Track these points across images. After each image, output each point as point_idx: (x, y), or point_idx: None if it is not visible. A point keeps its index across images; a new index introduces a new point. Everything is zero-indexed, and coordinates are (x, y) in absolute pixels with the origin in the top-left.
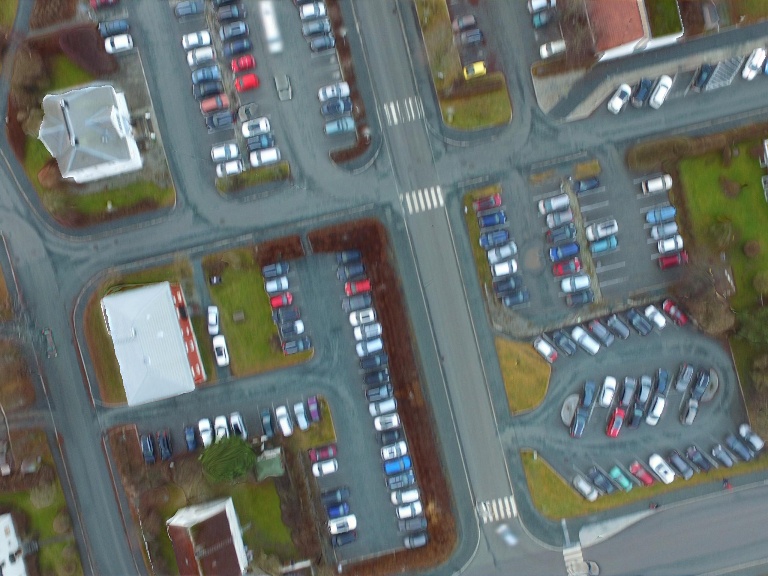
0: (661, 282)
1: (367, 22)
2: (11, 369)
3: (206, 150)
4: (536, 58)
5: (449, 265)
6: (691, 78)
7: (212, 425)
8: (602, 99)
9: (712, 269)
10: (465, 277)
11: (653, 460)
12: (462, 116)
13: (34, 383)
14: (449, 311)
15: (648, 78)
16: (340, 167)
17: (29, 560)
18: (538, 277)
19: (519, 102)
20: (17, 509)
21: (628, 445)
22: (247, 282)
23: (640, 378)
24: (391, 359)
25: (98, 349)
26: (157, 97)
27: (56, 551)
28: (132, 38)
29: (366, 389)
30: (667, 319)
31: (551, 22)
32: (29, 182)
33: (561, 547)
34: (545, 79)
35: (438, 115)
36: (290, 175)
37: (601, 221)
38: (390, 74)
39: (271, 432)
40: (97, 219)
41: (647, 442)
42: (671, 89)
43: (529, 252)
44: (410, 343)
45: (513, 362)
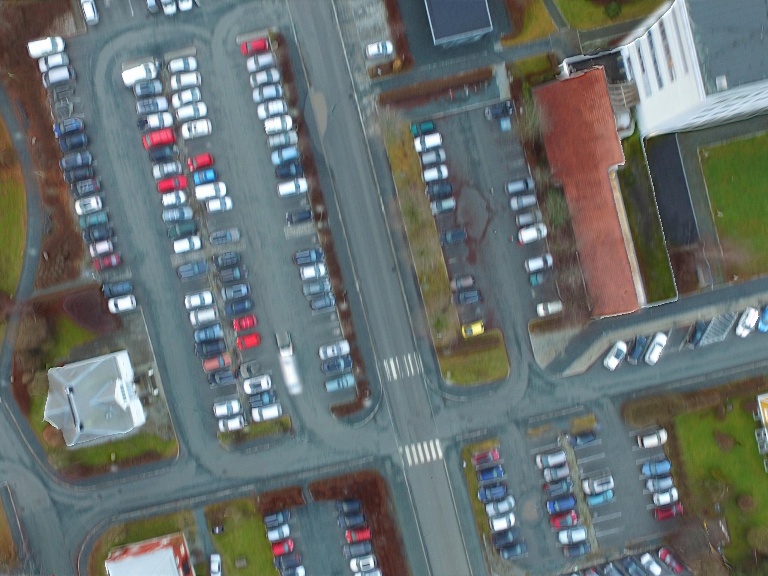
0: (657, 532)
1: (367, 280)
2: None
3: (208, 404)
4: (533, 315)
5: (448, 515)
6: (685, 334)
7: None
8: (598, 355)
9: (707, 520)
10: (464, 527)
11: None
12: (460, 372)
13: None
14: (448, 559)
15: (643, 335)
16: (340, 421)
17: None
18: (536, 528)
19: (516, 358)
20: None
21: None
22: (249, 529)
23: None
24: None
25: None
26: (160, 353)
27: None
28: (135, 298)
29: None
30: (663, 565)
31: (548, 282)
32: (34, 435)
33: None
34: (542, 335)
35: (437, 371)
36: (291, 428)
37: (597, 477)
38: (389, 331)
39: None
40: (101, 470)
41: None
42: (666, 345)
43: (527, 504)
44: None
45: None
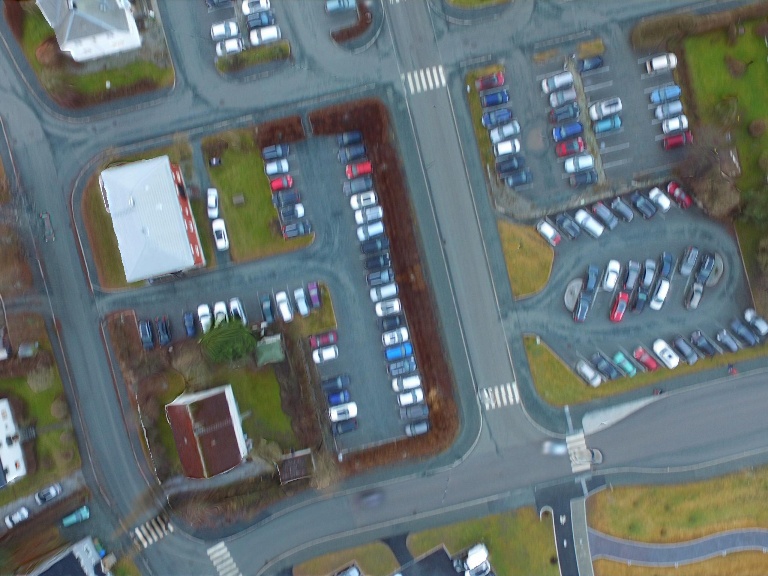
0: (665, 163)
1: None
2: (8, 252)
3: (206, 29)
4: None
5: (451, 146)
6: None
7: (211, 311)
8: None
9: (717, 150)
10: (467, 158)
11: (657, 345)
12: None
13: (32, 267)
14: (451, 193)
15: None
16: (341, 46)
17: (26, 447)
18: (541, 158)
19: None
20: (14, 395)
21: (632, 331)
22: (247, 165)
23: (644, 262)
24: (392, 243)
25: (96, 233)
26: None
27: (54, 439)
28: None
29: (367, 274)
30: (671, 202)
31: None
32: (27, 62)
33: (564, 434)
34: None
35: None
36: (290, 55)
37: (605, 99)
38: None
39: (271, 318)
40: (95, 100)
41: (651, 328)
42: None
43: (532, 132)
44: (412, 225)
45: (516, 245)
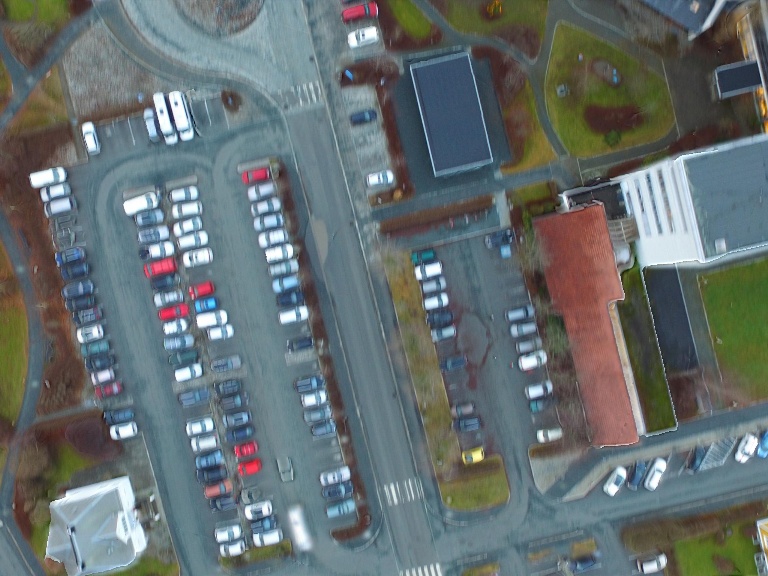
0: None
1: (367, 406)
2: None
3: (210, 528)
4: (533, 441)
5: None
6: (685, 459)
7: None
8: (598, 480)
9: None
10: None
11: None
12: (461, 498)
13: None
14: None
15: (643, 461)
16: (341, 545)
17: None
18: None
19: (517, 483)
20: None
21: None
22: None
23: None
24: None
25: None
26: (161, 478)
27: None
28: (137, 424)
29: None
30: None
31: (548, 408)
32: (36, 558)
33: None
34: (542, 461)
35: (437, 496)
36: (292, 552)
37: None
38: (390, 456)
39: None
40: None
41: None
42: (665, 470)
43: None
44: None
45: None
